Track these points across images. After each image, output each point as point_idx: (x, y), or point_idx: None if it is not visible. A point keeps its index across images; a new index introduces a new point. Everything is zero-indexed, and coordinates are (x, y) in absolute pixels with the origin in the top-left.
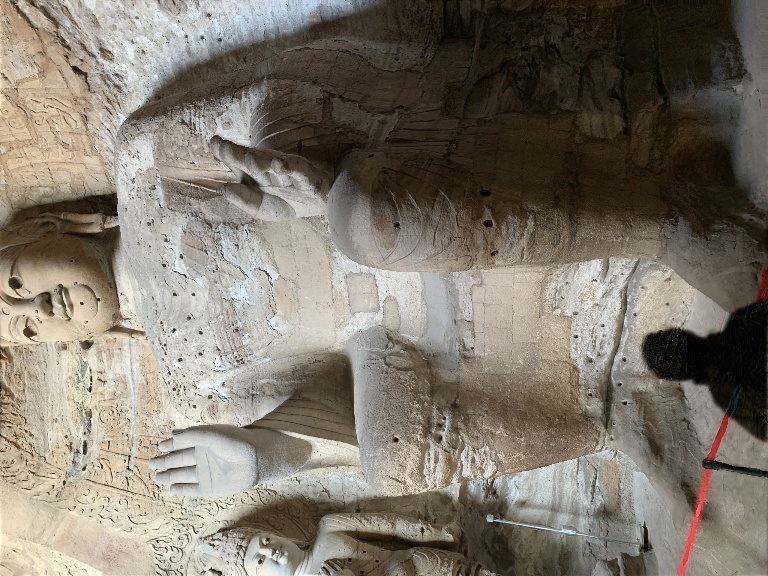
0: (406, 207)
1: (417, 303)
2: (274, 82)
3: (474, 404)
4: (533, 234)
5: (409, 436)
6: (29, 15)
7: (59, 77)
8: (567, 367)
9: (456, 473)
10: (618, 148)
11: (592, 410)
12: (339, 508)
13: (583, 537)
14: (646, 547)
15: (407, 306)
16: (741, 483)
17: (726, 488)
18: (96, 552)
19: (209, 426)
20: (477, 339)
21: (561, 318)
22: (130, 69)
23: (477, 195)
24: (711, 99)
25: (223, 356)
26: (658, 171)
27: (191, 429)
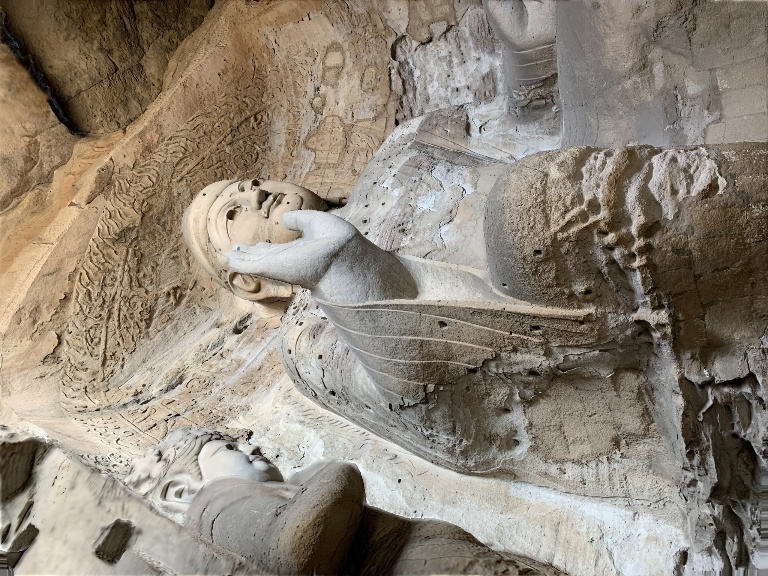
0: None
1: None
2: None
3: None
4: None
5: None
6: (393, 82)
7: (384, 123)
8: None
9: (638, 176)
10: None
11: None
12: None
13: None
14: None
15: None
16: None
17: None
18: (55, 430)
19: None
20: None
21: None
22: None
23: None
24: None
25: None
26: None
27: None
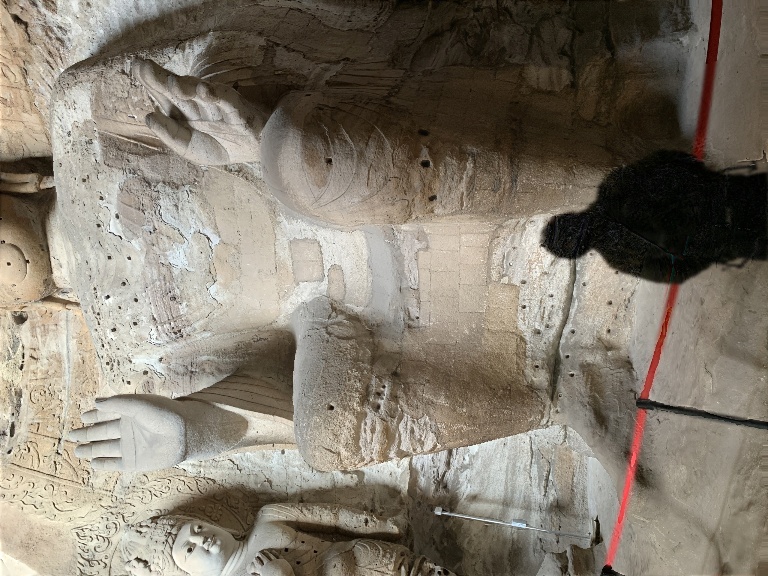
0: (339, 142)
1: (363, 271)
2: (219, 33)
3: (416, 373)
4: (472, 177)
5: (345, 404)
6: None
7: None
8: (514, 338)
9: (394, 445)
10: (564, 100)
11: (538, 382)
12: (281, 499)
13: (534, 532)
14: (597, 540)
15: (352, 275)
16: (683, 443)
17: (669, 452)
18: (14, 540)
19: None
20: (422, 308)
21: (509, 287)
22: (74, 22)
23: (415, 134)
24: (658, 52)
25: (159, 327)
26: (604, 124)
27: (116, 397)
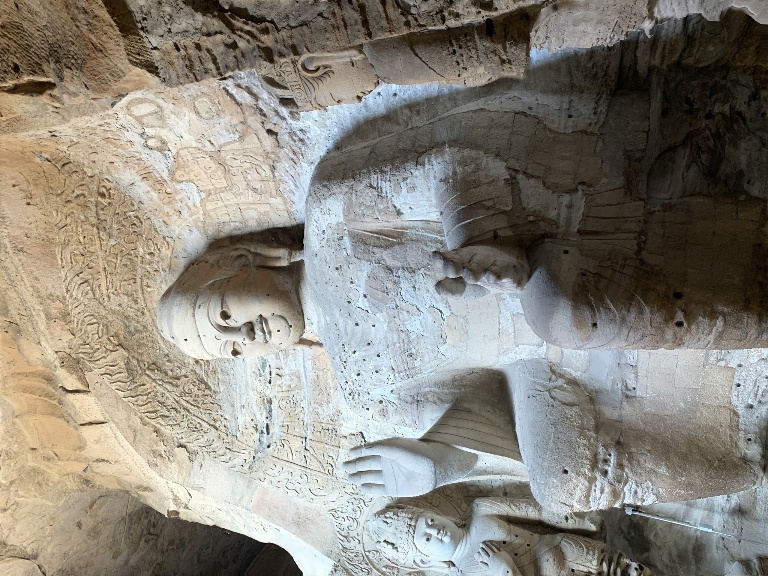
0: (604, 310)
1: None
2: (457, 152)
3: (637, 443)
4: (721, 332)
5: (578, 469)
6: (235, 95)
7: (255, 139)
8: (727, 412)
9: (619, 501)
10: None
11: (751, 454)
12: (488, 491)
13: None
14: None
15: None
16: None
17: None
18: (287, 518)
19: (394, 442)
20: (640, 381)
21: (725, 369)
22: (313, 125)
23: (670, 298)
24: None
25: (396, 374)
26: None
27: (380, 444)
